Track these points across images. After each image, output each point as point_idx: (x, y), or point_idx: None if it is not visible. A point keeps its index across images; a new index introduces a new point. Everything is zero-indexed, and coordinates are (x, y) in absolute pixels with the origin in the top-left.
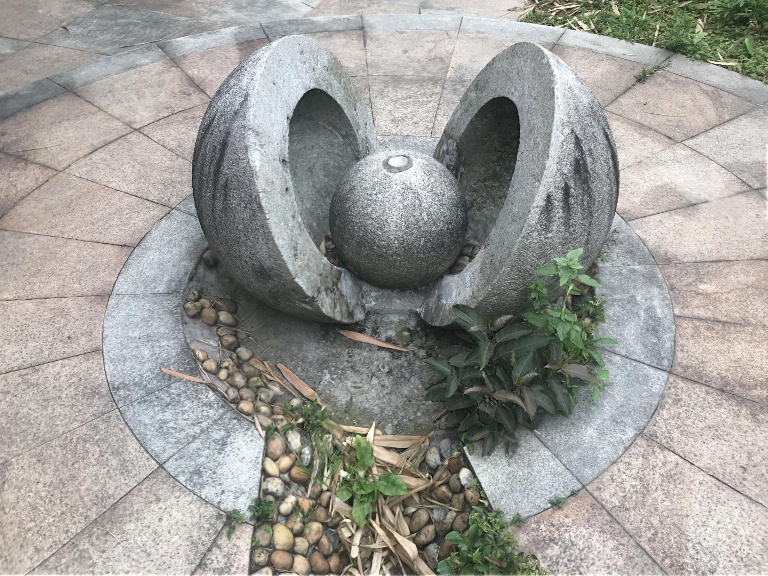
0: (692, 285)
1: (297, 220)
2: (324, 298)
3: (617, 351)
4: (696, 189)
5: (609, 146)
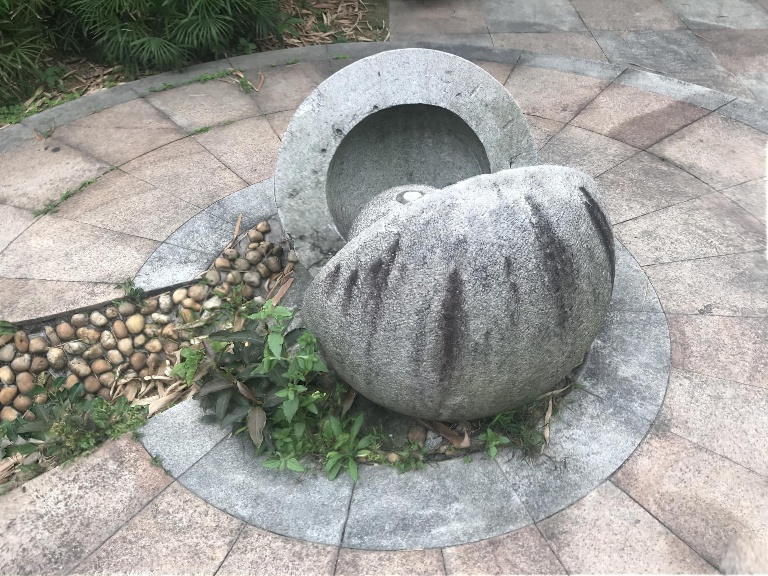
0: (512, 568)
1: (318, 177)
2: (305, 247)
3: (357, 490)
4: (763, 569)
5: (450, 291)
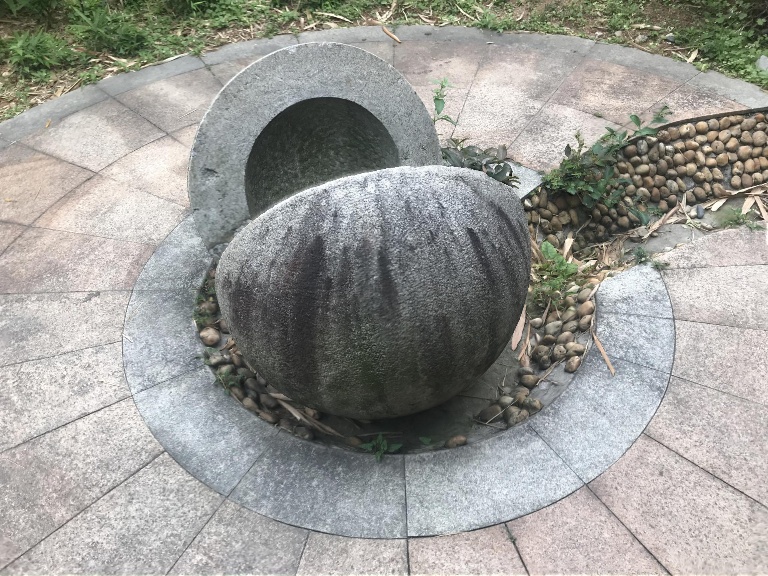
0: None
1: None
2: None
3: None
4: (176, 158)
5: None
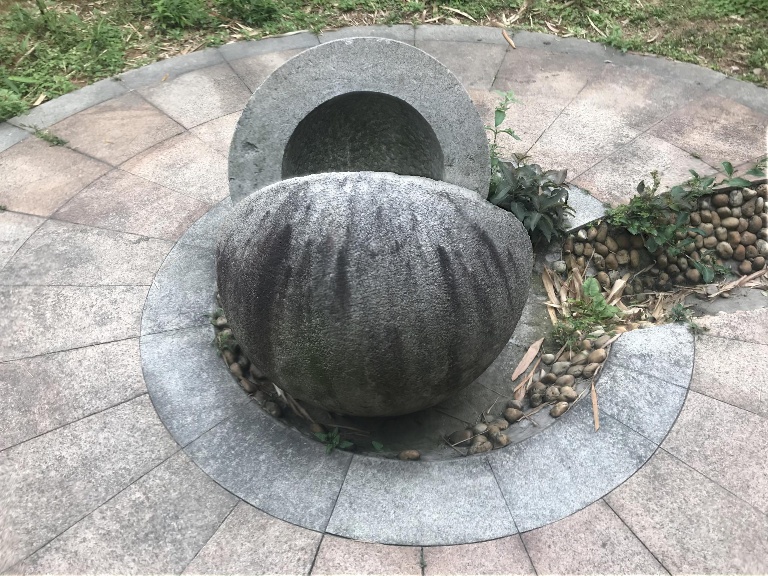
0: None
1: None
2: None
3: None
4: None
5: None
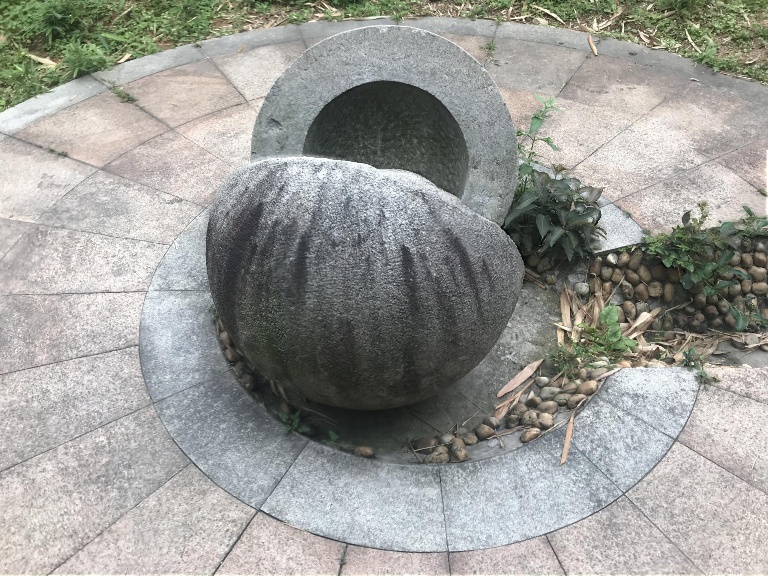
0: None
1: None
2: None
3: None
4: None
5: None
